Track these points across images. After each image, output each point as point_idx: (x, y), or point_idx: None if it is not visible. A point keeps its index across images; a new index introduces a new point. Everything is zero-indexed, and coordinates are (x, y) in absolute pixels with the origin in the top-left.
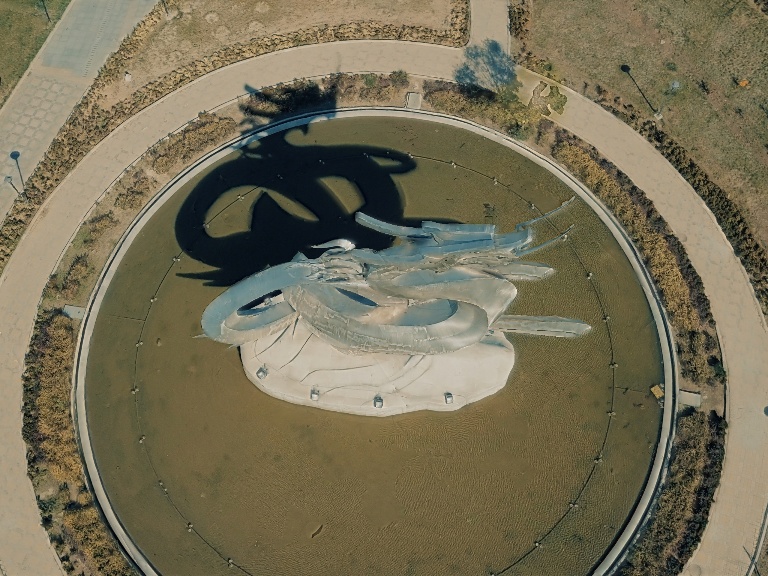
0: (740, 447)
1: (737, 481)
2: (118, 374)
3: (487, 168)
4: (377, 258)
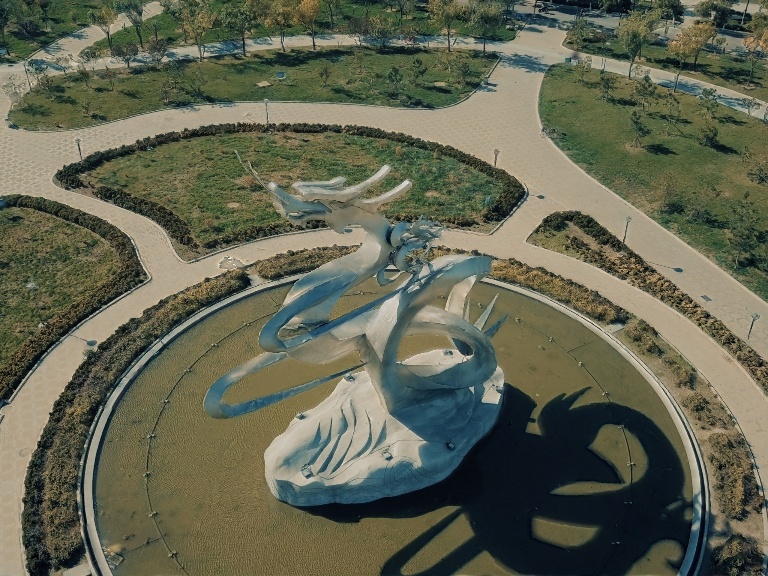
0: (7, 562)
1: (3, 533)
2: (540, 322)
3: None
4: (372, 178)
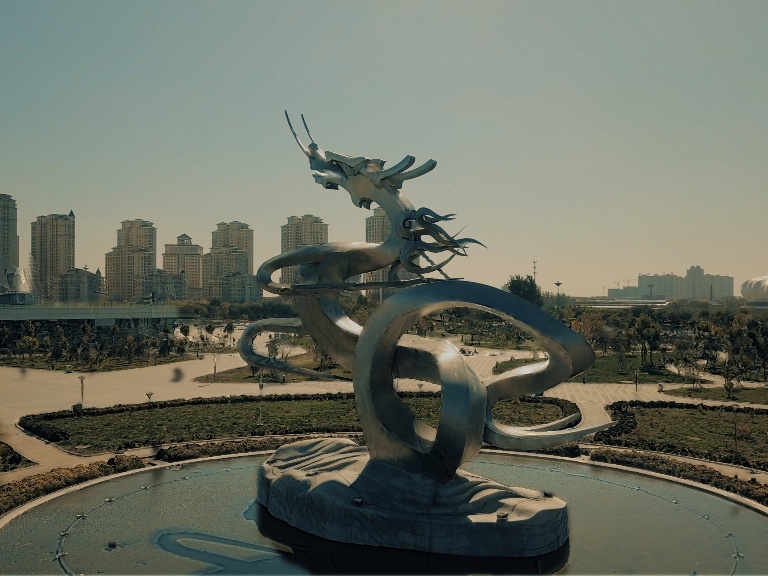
0: None
1: None
2: (767, 571)
3: (44, 569)
4: None
